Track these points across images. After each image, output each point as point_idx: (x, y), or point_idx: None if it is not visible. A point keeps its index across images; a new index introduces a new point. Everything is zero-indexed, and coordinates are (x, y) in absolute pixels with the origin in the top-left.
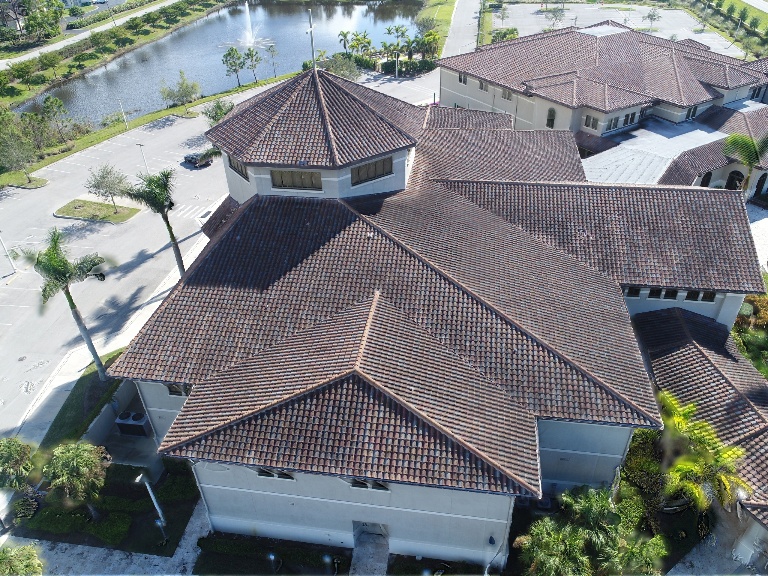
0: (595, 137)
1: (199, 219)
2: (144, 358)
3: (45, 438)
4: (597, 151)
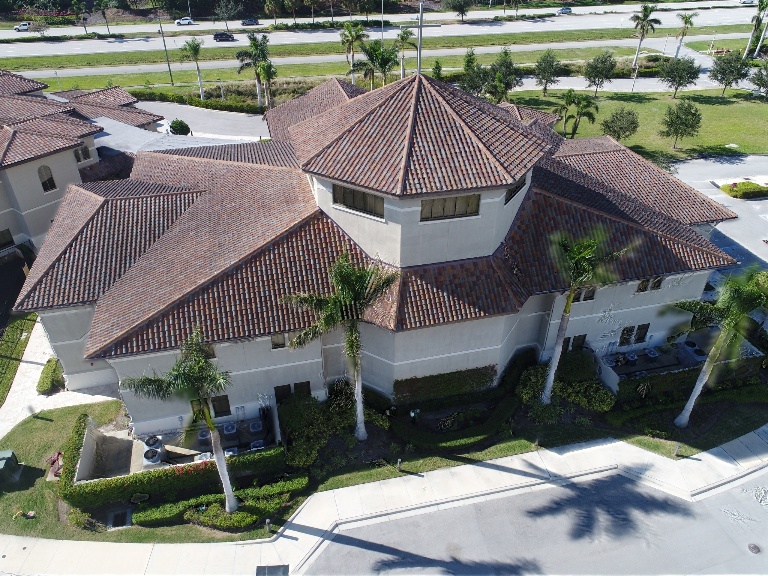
0: (97, 165)
1: (297, 570)
2: (706, 245)
3: (767, 422)
4: (122, 170)
